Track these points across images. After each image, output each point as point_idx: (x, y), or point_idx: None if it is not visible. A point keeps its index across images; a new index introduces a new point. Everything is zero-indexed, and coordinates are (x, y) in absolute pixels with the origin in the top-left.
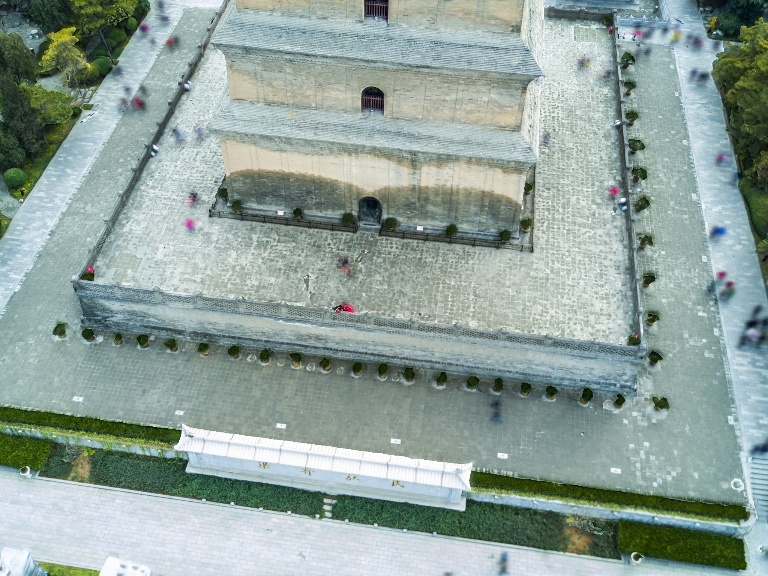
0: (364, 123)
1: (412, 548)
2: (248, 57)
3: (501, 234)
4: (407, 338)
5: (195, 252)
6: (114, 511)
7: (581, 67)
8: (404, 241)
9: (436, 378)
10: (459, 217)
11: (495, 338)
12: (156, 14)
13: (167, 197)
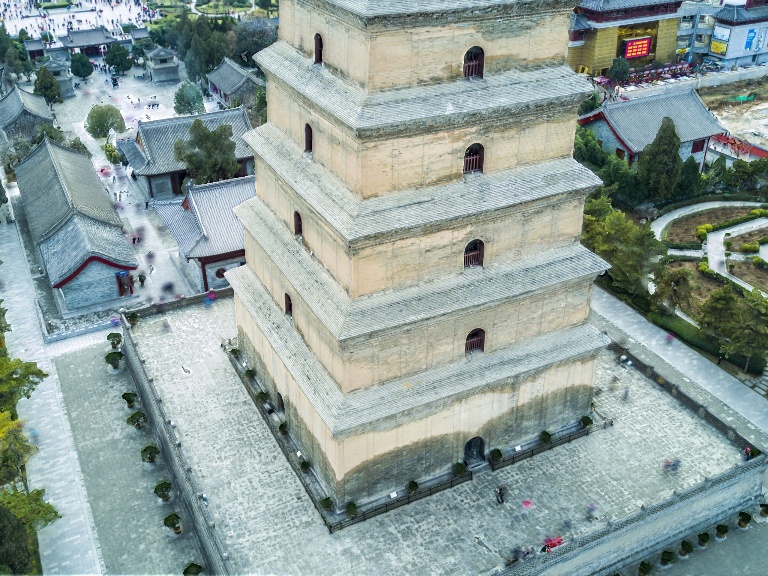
0: (471, 366)
1: None
2: (368, 343)
3: (584, 421)
4: (604, 546)
5: (354, 575)
6: None
7: None
8: (516, 466)
9: (634, 573)
10: (547, 422)
11: (671, 505)
12: None
13: (266, 538)
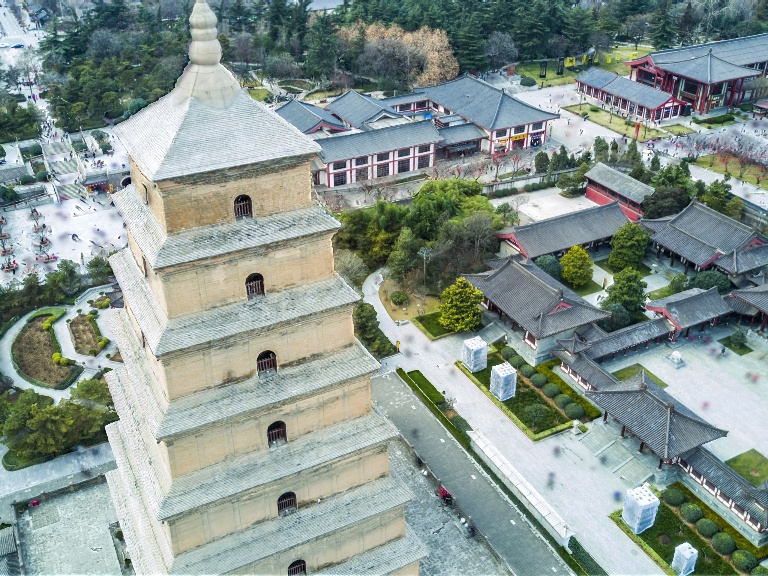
0: None
1: (509, 457)
2: None
3: None
4: None
5: None
6: (620, 570)
7: (103, 503)
8: None
9: None
10: None
11: None
12: None
13: None
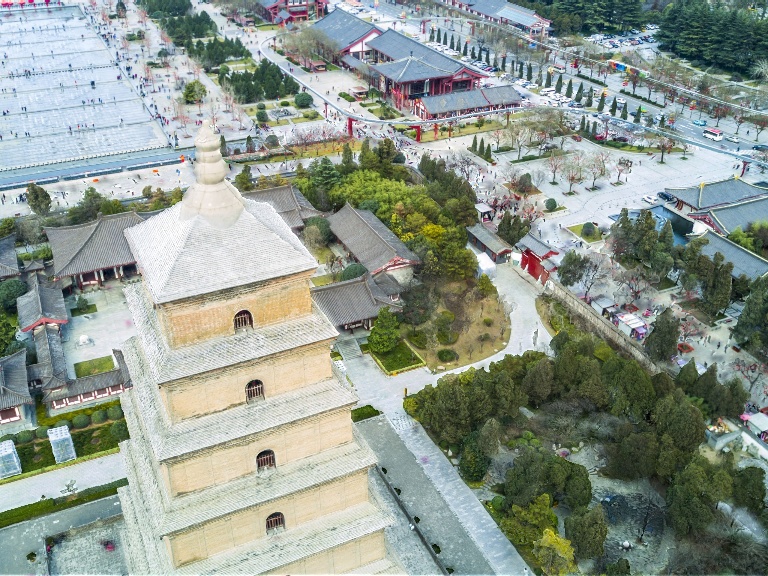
0: None
1: None
2: None
3: None
4: None
5: None
6: None
7: None
8: None
9: None
10: None
11: None
12: None
13: None
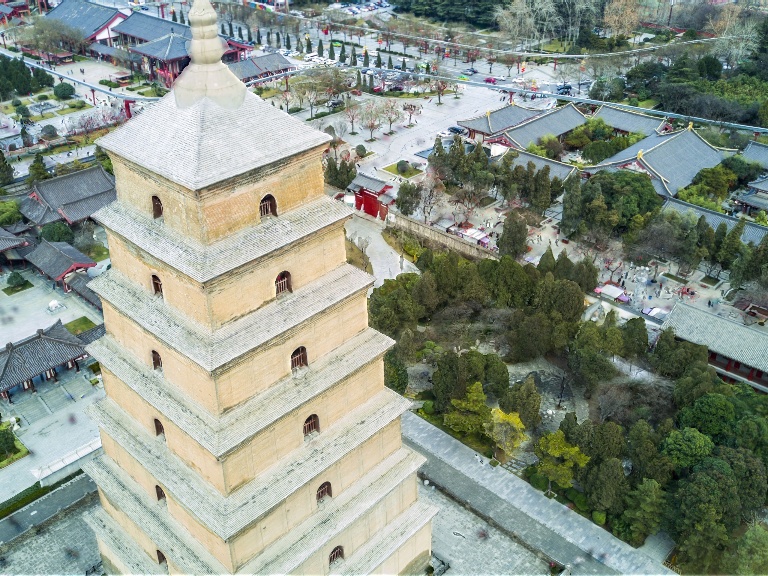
0: None
1: None
2: None
3: None
4: None
5: None
6: None
7: None
8: None
9: None
10: None
11: None
12: (622, 549)
13: None
